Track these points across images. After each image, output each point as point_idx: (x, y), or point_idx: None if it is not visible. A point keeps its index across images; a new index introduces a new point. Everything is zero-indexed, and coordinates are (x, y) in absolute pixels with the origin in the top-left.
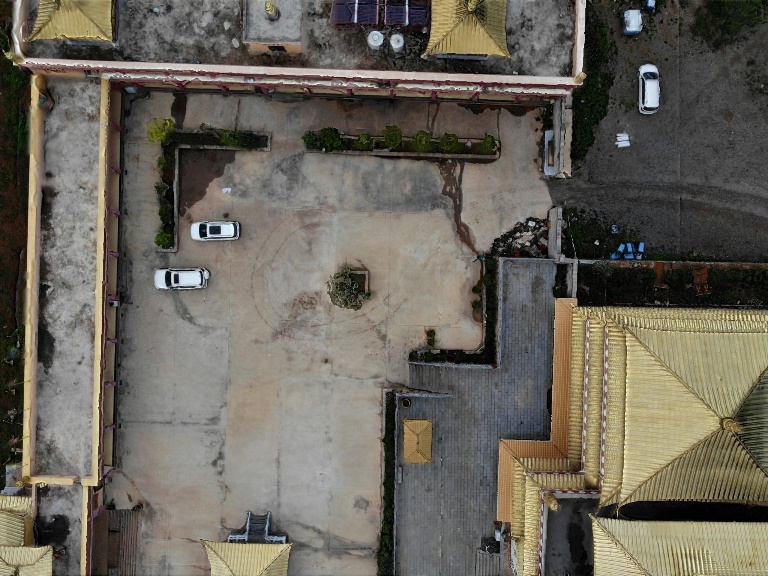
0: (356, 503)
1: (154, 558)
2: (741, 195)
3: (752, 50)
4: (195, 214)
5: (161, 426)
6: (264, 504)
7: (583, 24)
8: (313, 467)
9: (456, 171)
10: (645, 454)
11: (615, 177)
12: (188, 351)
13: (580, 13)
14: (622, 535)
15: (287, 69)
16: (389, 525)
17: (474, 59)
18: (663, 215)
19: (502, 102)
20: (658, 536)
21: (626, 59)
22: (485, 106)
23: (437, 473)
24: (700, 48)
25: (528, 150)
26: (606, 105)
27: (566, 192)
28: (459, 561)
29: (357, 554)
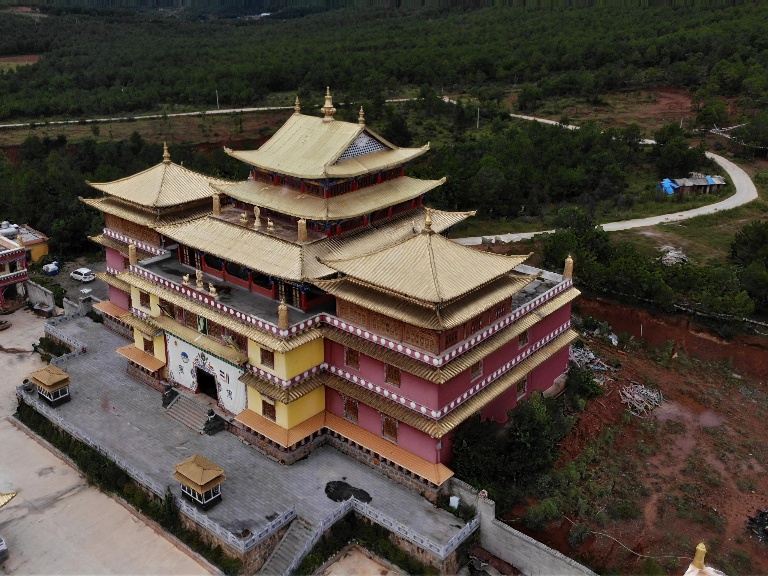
0: (40, 474)
1: None
2: None
3: None
4: None
5: None
6: None
7: None
8: None
9: None
10: None
11: None
12: None
13: None
14: None
15: None
16: None
17: None
18: None
19: None
20: None
21: None
22: None
23: (91, 404)
24: None
25: None
26: None
27: None
28: (157, 423)
29: (69, 495)
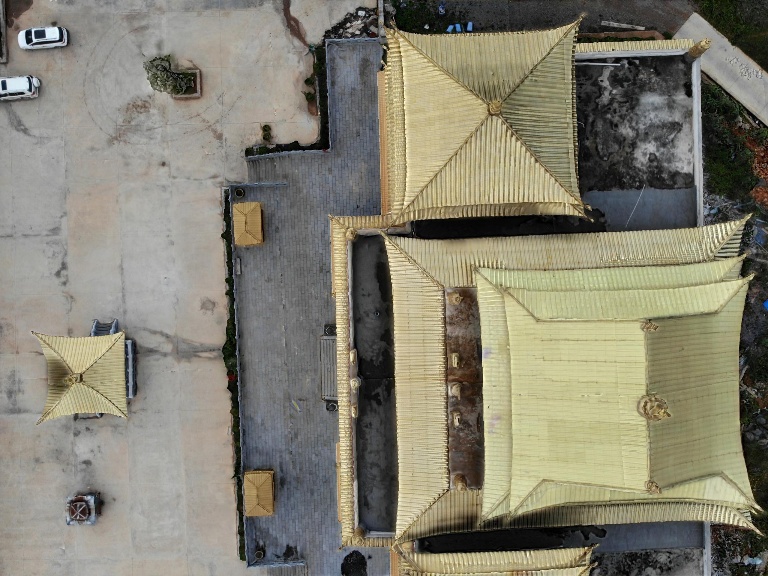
0: (202, 305)
1: (3, 373)
2: None
3: None
4: (23, 24)
5: (2, 240)
6: (110, 312)
7: None
8: (157, 271)
9: None
10: (425, 159)
11: None
12: (25, 163)
13: None
14: (415, 252)
15: None
16: (232, 320)
17: None
18: None
19: None
20: (453, 252)
21: None
22: None
23: (276, 263)
24: None
25: None
26: None
27: None
28: (304, 350)
29: (206, 356)
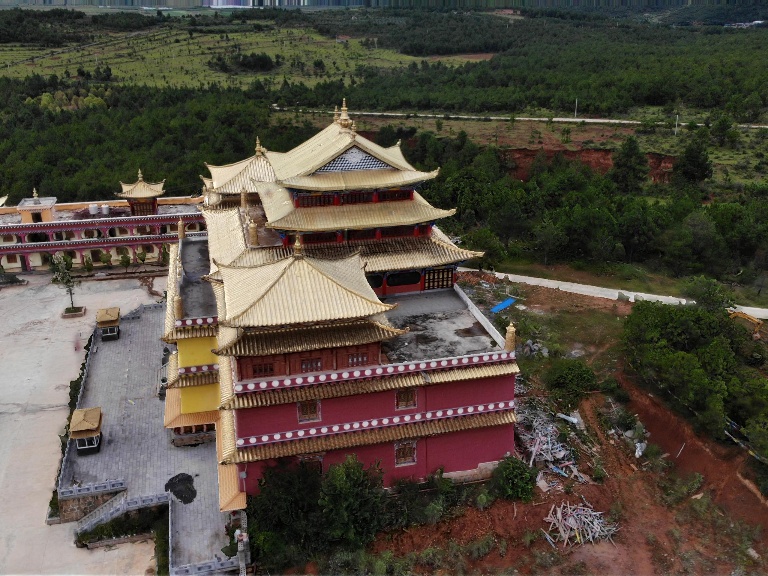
0: None
1: None
2: None
3: None
4: None
5: None
6: None
7: None
8: None
9: None
10: None
11: None
12: None
13: None
14: None
15: (42, 222)
16: None
17: None
18: None
19: None
20: None
21: None
22: None
23: None
24: None
25: None
26: None
27: None
28: (143, 377)
29: (52, 410)
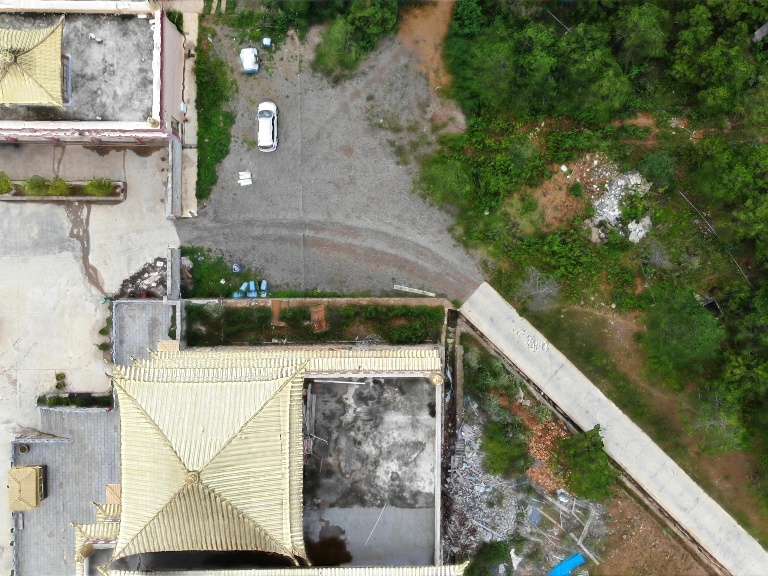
0: None
1: None
2: (362, 230)
3: (371, 85)
4: None
5: None
6: None
7: (158, 68)
8: None
9: (83, 213)
10: (137, 507)
11: (239, 215)
12: None
13: (154, 57)
14: None
15: None
16: None
17: (56, 105)
18: (287, 252)
19: (125, 143)
20: None
21: (247, 97)
22: (111, 148)
23: (59, 518)
24: (320, 84)
25: (155, 190)
26: (228, 144)
27: (193, 231)
28: None
29: None
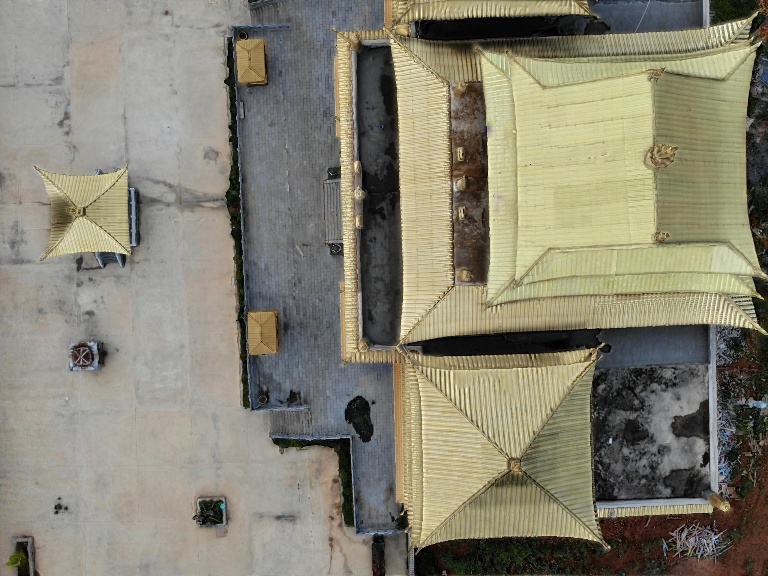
0: (205, 155)
1: (6, 224)
2: None
3: None
4: None
5: (5, 90)
6: (113, 162)
7: None
8: (160, 121)
9: None
10: None
11: None
12: (27, 12)
13: None
14: (420, 50)
15: None
16: (236, 166)
17: None
18: None
19: None
20: (458, 52)
21: None
22: None
23: (279, 107)
24: None
25: None
26: None
27: None
28: (307, 195)
29: (210, 206)
